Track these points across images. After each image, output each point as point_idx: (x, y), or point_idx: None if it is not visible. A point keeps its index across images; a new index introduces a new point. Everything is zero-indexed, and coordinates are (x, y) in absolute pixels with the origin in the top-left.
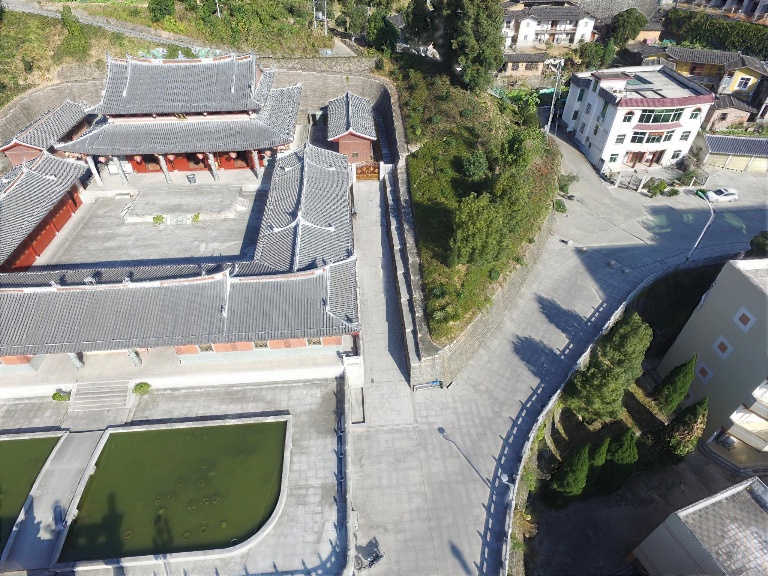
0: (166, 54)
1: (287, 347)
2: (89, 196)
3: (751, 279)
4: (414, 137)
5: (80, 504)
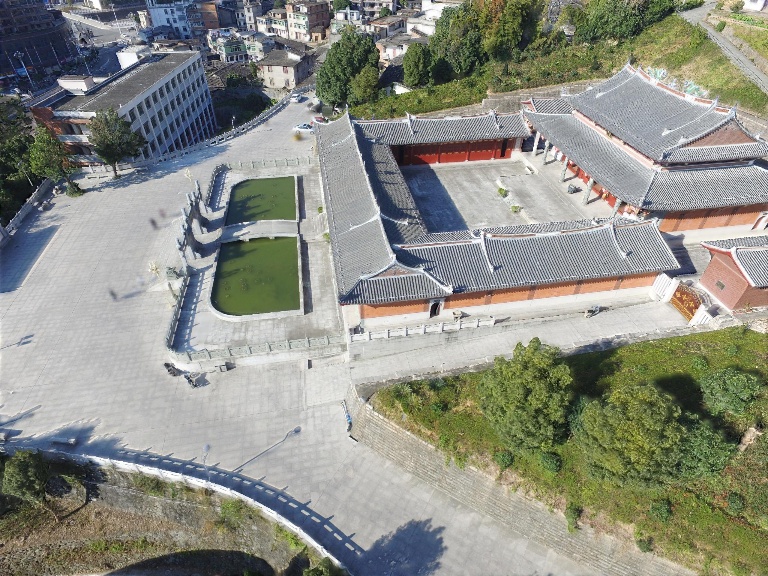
0: (664, 77)
1: None
2: (518, 157)
3: None
4: None
5: (253, 240)
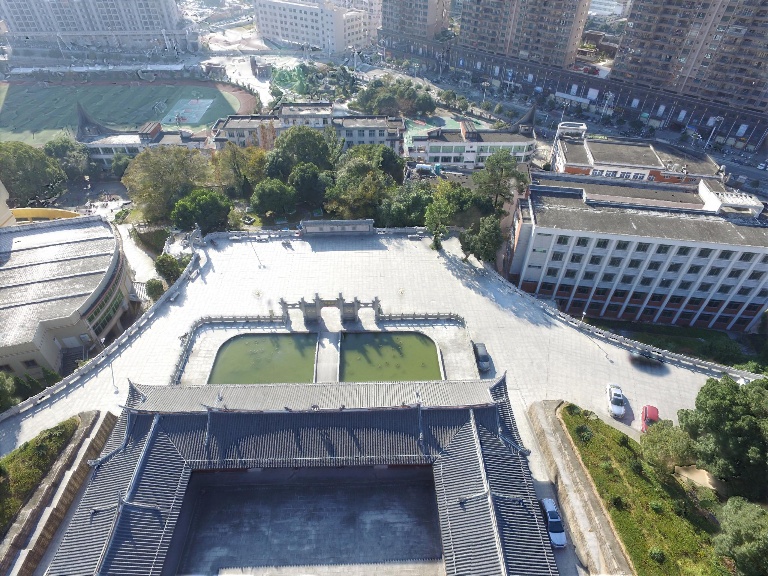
0: None
1: None
2: None
3: None
4: None
5: None
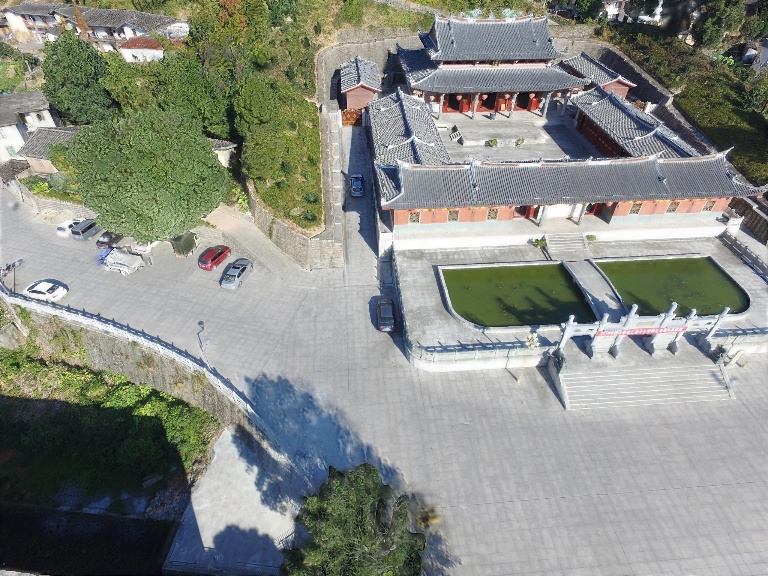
0: None
1: (687, 212)
2: None
3: None
4: (674, 83)
5: None
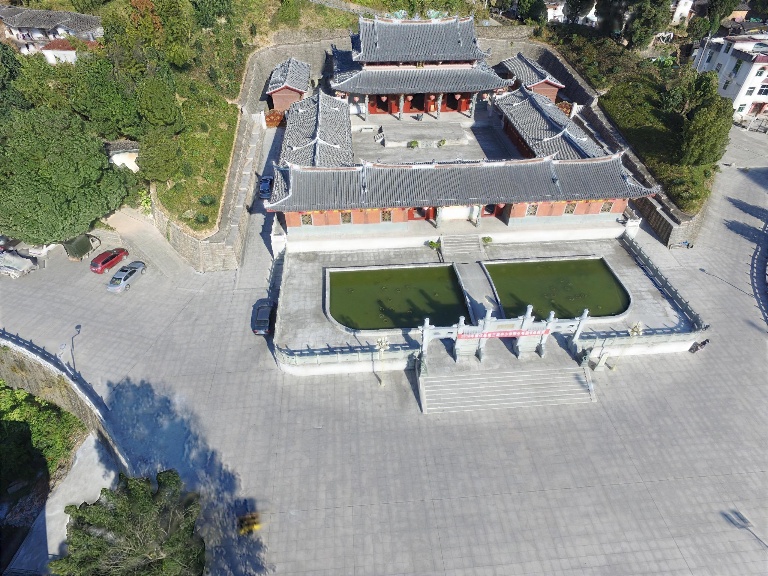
0: None
1: (586, 213)
2: None
3: None
4: (601, 83)
5: None
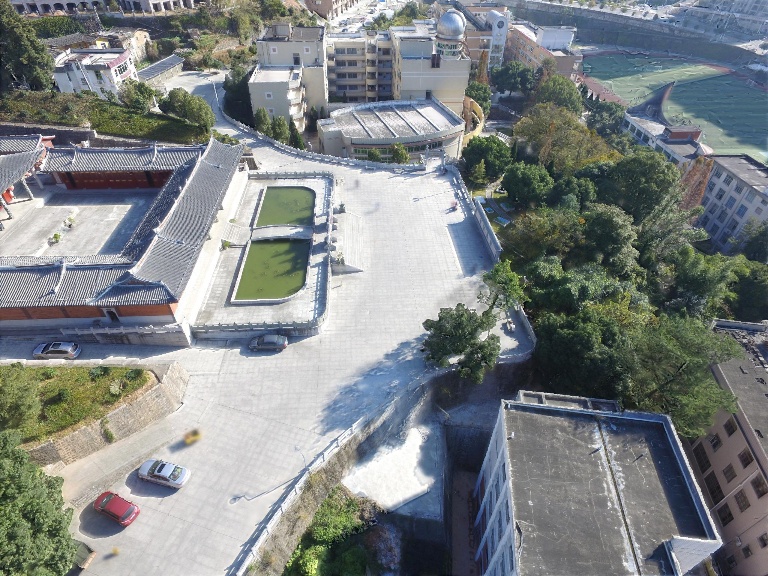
0: None
1: None
2: None
3: (259, 82)
4: (77, 120)
5: None
